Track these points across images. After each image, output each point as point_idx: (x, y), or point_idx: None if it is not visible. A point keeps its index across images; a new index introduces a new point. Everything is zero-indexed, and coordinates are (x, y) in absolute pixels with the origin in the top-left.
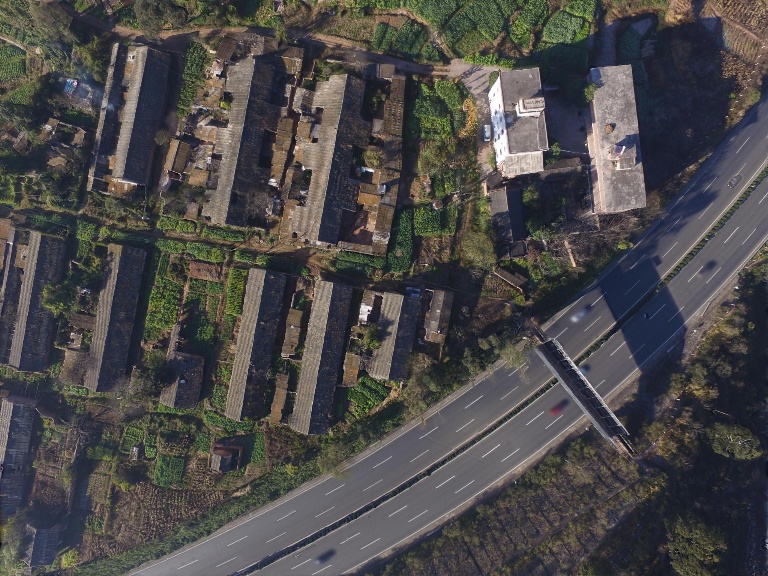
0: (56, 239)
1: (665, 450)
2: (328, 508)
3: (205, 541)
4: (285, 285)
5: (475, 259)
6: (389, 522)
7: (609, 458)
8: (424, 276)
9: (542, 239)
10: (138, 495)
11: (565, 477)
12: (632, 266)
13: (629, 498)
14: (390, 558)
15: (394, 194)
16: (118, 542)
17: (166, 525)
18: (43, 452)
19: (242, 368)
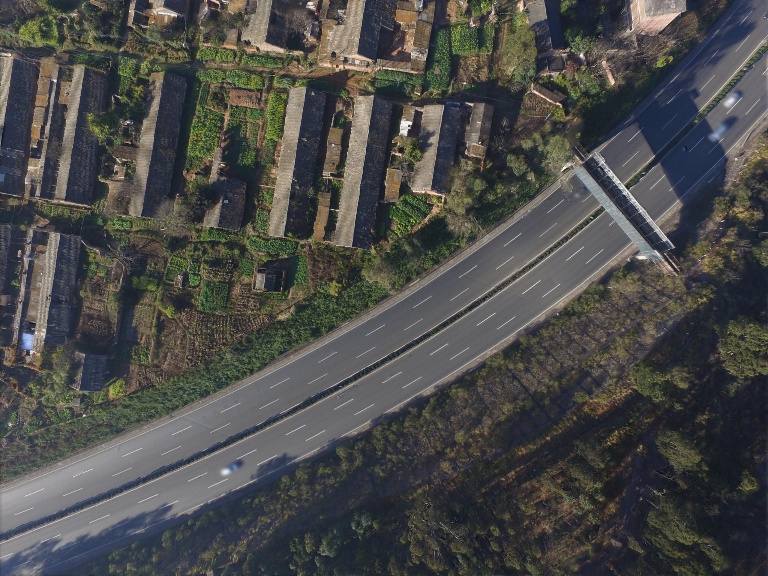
0: (99, 73)
1: (711, 267)
2: (369, 348)
3: (247, 384)
4: (325, 105)
5: (513, 78)
6: (431, 360)
7: (654, 279)
8: (463, 94)
9: (581, 52)
10: (183, 322)
11: (609, 302)
12: (669, 101)
13: (677, 309)
14: (433, 395)
15: (431, 11)
16: (164, 370)
17: (211, 351)
18: (89, 285)
19: (285, 185)
